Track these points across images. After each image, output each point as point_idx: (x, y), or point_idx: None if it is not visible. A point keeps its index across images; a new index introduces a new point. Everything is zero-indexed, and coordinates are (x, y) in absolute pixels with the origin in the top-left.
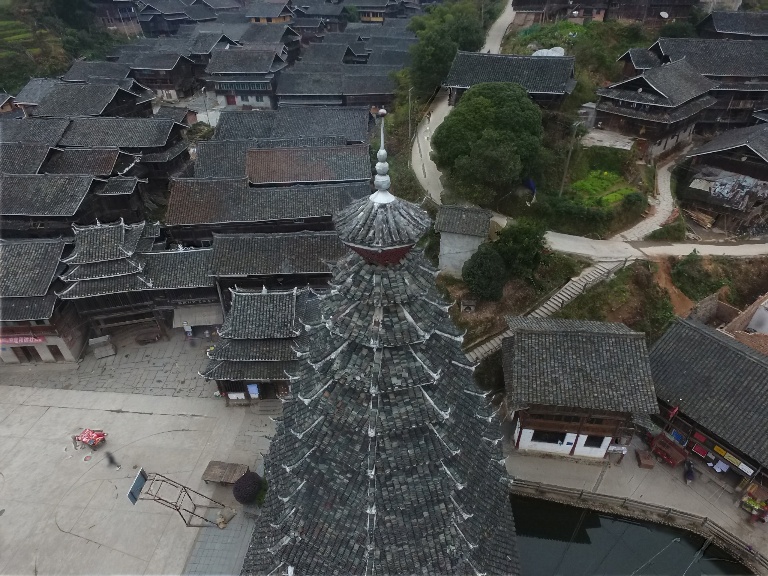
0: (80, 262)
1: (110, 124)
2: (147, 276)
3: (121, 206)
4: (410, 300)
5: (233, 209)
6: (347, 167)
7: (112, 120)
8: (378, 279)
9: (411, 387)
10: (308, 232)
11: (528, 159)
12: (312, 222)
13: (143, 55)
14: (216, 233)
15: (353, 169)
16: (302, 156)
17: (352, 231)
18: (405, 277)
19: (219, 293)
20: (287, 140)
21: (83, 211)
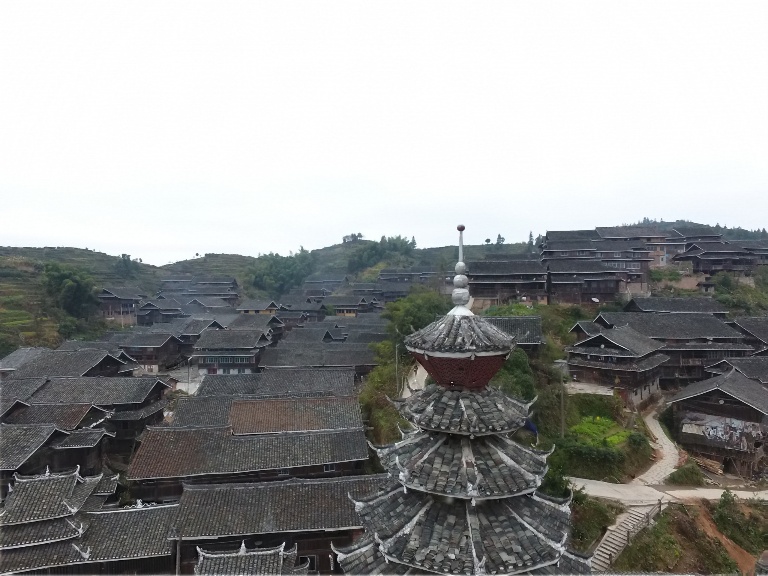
0: (4, 523)
1: (89, 383)
2: (85, 543)
3: (75, 463)
4: (510, 427)
5: (210, 459)
6: (337, 417)
7: (92, 379)
8: (467, 402)
9: (528, 570)
10: (297, 480)
11: (525, 396)
12: (299, 473)
13: (135, 335)
14: (187, 484)
15: (343, 418)
16: (290, 407)
17: (436, 340)
18: (497, 402)
19: (177, 563)
20: (273, 396)
21: (29, 465)
